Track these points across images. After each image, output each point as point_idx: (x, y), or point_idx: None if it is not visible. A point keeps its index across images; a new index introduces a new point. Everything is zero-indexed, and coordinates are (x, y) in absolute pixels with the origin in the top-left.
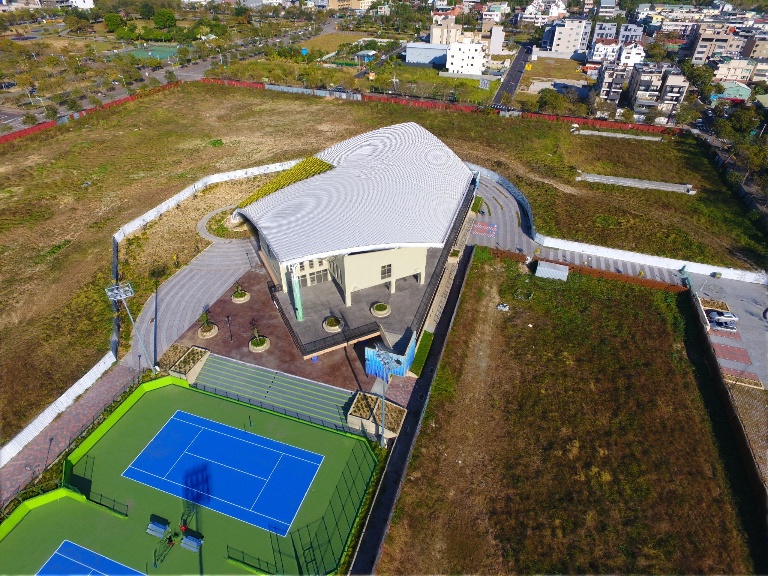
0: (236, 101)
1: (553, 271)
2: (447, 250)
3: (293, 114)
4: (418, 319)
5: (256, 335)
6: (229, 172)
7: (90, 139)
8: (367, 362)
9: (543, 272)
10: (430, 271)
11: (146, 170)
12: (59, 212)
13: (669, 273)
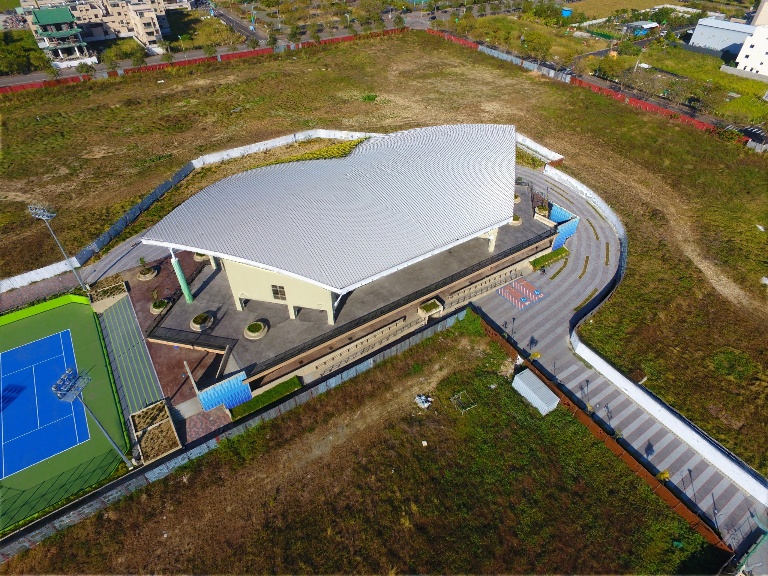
0: (437, 58)
1: (531, 393)
2: (404, 299)
3: (476, 84)
4: (275, 360)
5: (155, 297)
6: (336, 131)
7: (282, 70)
8: (183, 376)
9: (520, 386)
10: (358, 314)
11: (287, 109)
12: (194, 129)
13: (744, 504)
